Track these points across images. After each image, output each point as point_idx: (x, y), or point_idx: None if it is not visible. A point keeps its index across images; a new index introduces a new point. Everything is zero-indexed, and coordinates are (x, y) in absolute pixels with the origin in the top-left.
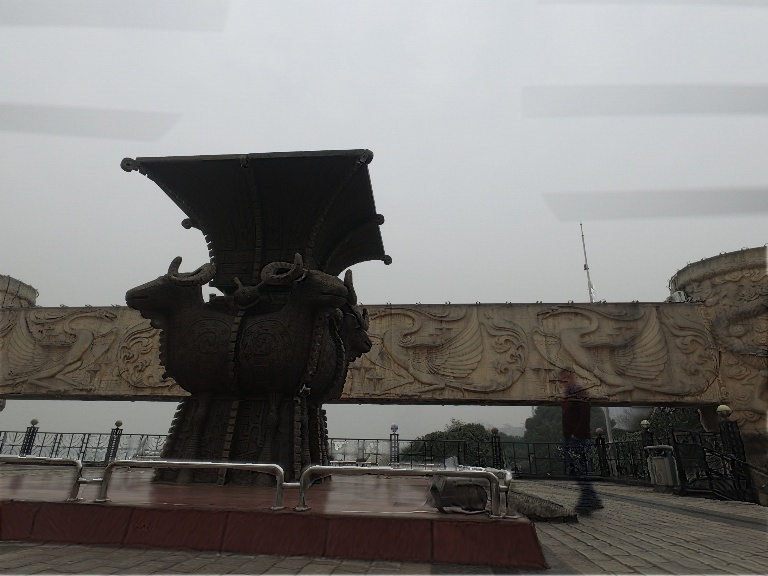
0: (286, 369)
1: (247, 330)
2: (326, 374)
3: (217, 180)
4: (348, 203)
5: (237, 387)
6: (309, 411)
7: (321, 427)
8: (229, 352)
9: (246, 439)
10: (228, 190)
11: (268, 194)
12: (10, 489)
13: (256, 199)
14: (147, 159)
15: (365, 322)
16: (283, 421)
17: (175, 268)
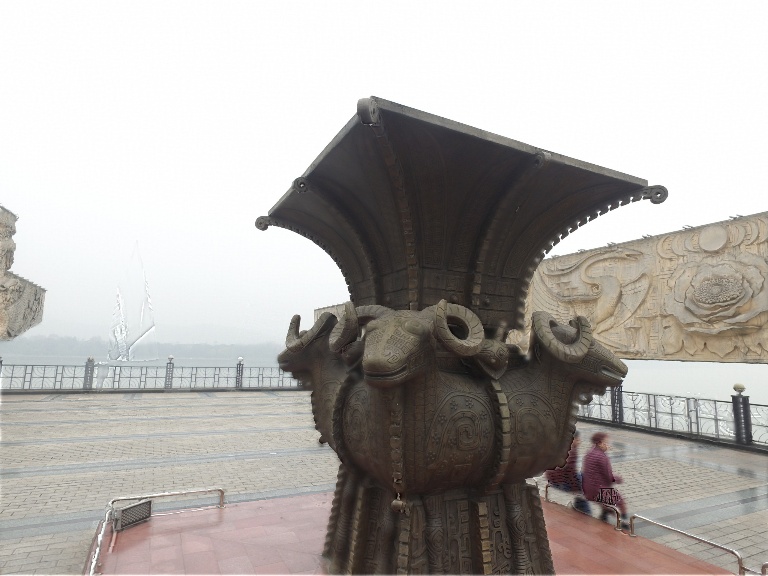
0: (376, 466)
1: (348, 402)
2: (457, 465)
3: (315, 208)
4: (449, 171)
5: (354, 473)
6: (470, 505)
7: (513, 522)
8: (332, 432)
9: (373, 541)
10: (328, 215)
11: (352, 206)
12: (165, 570)
13: (344, 218)
14: (271, 210)
15: (564, 350)
16: (398, 533)
17: (292, 329)
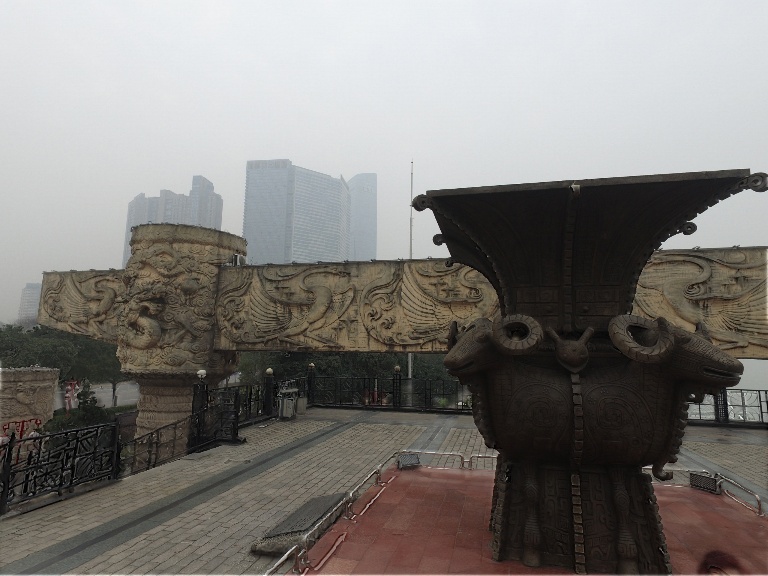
0: None
1: None
2: None
3: None
4: None
5: None
6: None
7: None
8: None
9: None
10: None
11: None
12: None
13: None
14: None
15: None
16: None
17: None
